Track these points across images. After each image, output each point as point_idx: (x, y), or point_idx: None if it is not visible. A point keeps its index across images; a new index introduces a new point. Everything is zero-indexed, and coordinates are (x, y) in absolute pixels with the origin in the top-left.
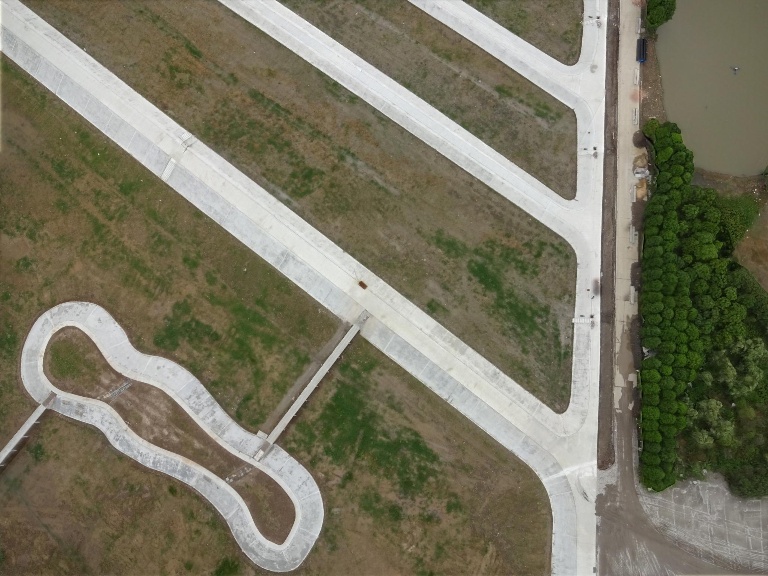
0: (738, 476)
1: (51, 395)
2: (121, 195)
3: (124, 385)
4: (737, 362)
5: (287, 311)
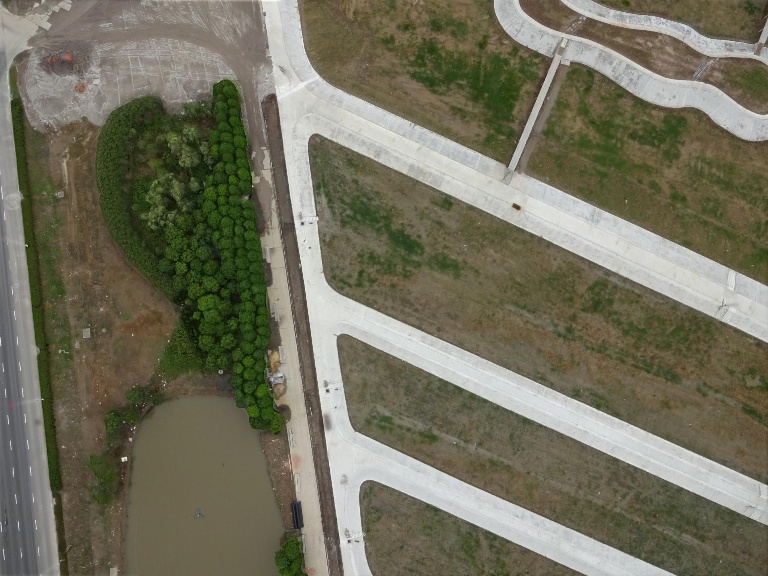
0: (157, 111)
1: (759, 53)
2: (767, 248)
3: (699, 74)
4: (170, 205)
5: (577, 172)
